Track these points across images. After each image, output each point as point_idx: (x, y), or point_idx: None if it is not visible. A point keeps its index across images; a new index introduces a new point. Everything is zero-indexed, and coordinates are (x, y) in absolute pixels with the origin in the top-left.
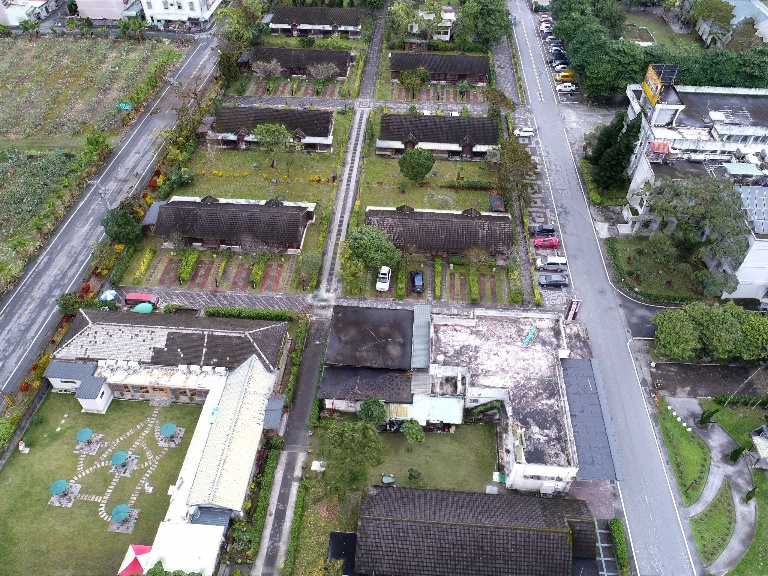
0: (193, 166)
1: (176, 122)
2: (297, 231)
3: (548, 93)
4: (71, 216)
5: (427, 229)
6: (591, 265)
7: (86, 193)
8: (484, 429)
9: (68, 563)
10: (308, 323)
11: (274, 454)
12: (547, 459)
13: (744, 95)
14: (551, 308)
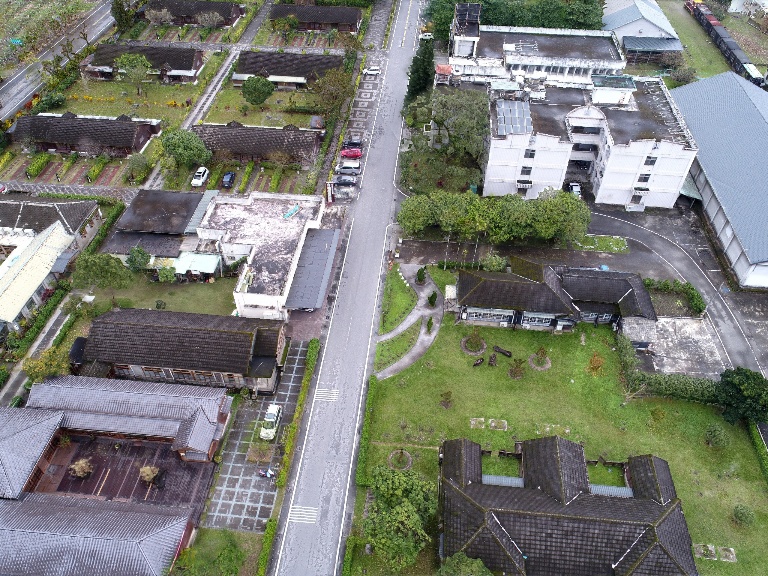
0: (70, 93)
1: (52, 53)
2: (132, 137)
3: (410, 41)
4: None
5: (241, 137)
6: (383, 171)
7: None
8: None
9: None
10: (125, 208)
11: (59, 293)
12: (265, 292)
13: (552, 35)
14: (335, 201)
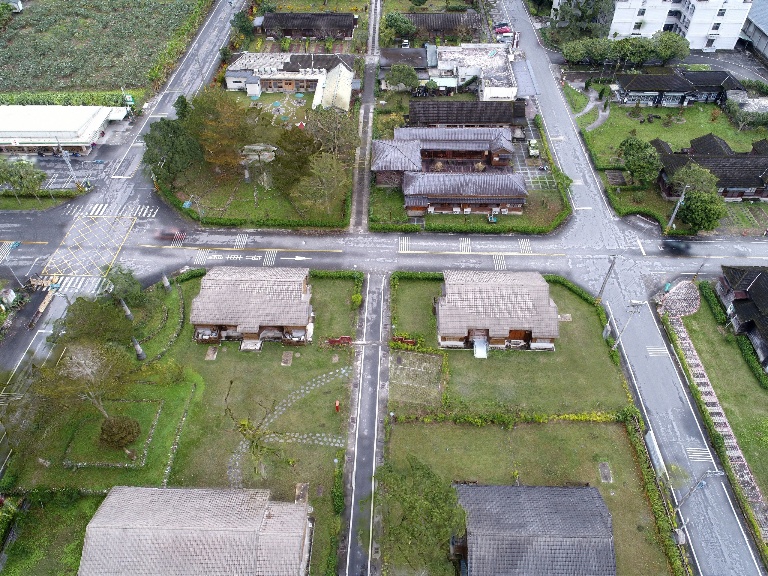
0: None
1: None
2: (351, 23)
3: None
4: (203, 28)
5: (430, 19)
6: (530, 39)
7: (208, 19)
8: (469, 95)
9: (263, 137)
10: None
11: (358, 103)
12: None
13: None
14: None
